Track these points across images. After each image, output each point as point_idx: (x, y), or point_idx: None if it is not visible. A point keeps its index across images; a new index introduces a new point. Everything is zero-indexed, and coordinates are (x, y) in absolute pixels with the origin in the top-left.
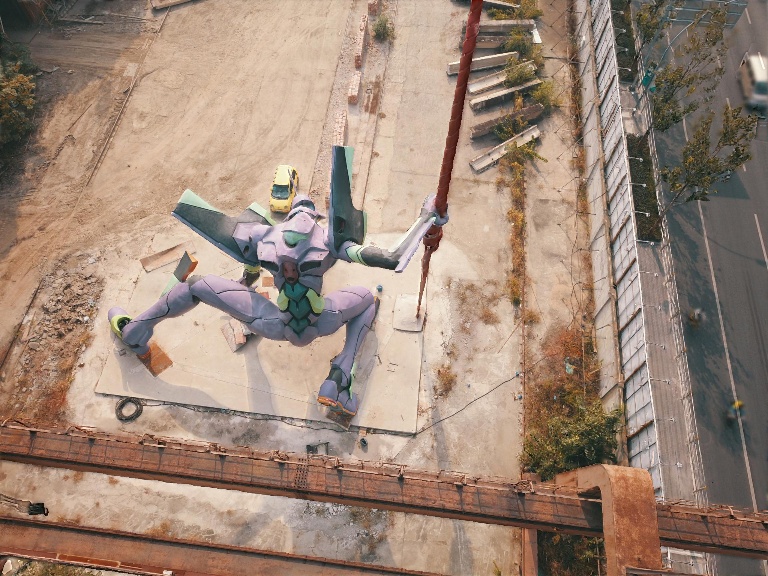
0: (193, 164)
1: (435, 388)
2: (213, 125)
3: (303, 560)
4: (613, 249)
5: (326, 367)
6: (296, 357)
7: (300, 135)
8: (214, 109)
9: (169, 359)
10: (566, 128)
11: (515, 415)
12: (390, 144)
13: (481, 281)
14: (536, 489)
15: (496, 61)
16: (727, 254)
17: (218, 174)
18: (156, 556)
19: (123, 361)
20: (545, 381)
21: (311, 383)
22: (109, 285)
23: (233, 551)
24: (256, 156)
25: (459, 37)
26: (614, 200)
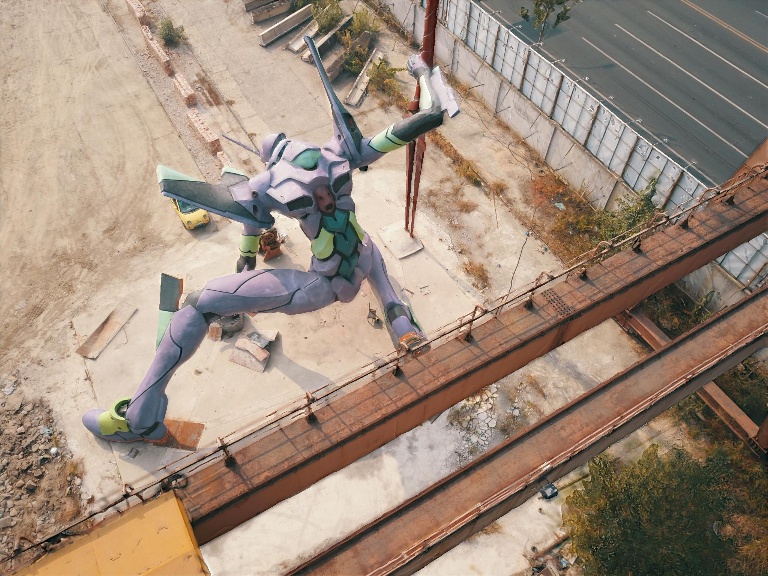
0: (59, 234)
1: (475, 285)
2: (52, 189)
3: (639, 366)
4: (524, 95)
5: (367, 327)
6: (330, 337)
7: (161, 154)
8: (41, 174)
9: (196, 424)
10: (398, 43)
11: (553, 265)
12: (259, 121)
13: (435, 184)
14: (735, 194)
15: (298, 18)
16: (589, 71)
17: (98, 229)
18: (507, 470)
19: (142, 461)
20: (552, 226)
21: (365, 349)
22: (54, 401)
23: (573, 407)
24: (128, 193)
25: (247, 16)
26: (497, 58)
